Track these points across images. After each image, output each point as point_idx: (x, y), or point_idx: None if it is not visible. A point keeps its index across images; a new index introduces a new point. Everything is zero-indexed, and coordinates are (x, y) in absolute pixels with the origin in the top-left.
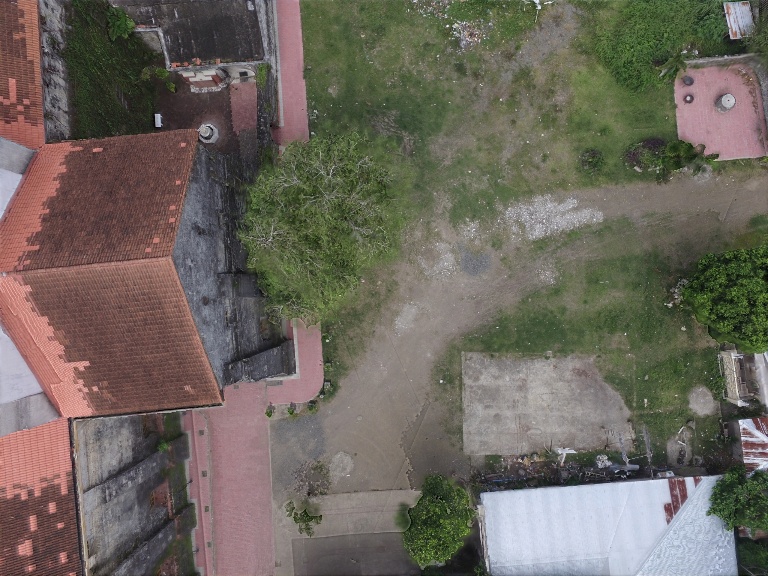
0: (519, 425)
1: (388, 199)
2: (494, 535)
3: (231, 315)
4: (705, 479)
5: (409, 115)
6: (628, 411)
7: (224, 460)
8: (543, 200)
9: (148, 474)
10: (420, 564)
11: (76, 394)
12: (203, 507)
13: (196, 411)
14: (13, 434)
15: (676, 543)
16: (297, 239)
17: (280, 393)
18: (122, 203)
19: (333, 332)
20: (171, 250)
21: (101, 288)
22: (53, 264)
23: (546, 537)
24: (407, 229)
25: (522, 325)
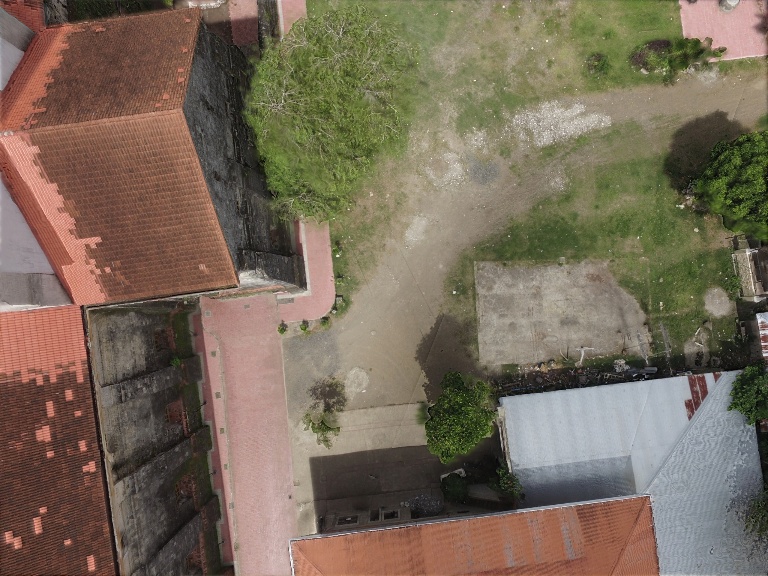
0: (535, 333)
1: (398, 71)
2: (515, 438)
3: (242, 206)
4: (725, 374)
5: (411, 25)
6: (644, 314)
7: (237, 381)
8: (550, 106)
9: (162, 386)
10: (442, 461)
11: (88, 277)
12: (218, 429)
13: (207, 332)
14: (25, 318)
15: (698, 439)
16: (309, 100)
17: (292, 311)
18: (129, 70)
19: (343, 247)
20: (182, 104)
21: (111, 148)
22: (61, 122)
23: (567, 438)
24: (414, 140)
25: (534, 233)
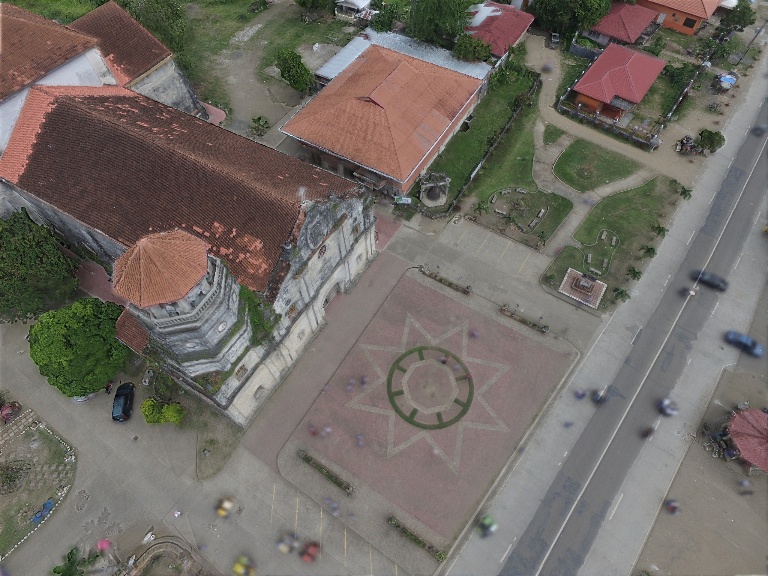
0: None
1: None
2: None
3: None
4: None
5: None
6: (331, 45)
7: None
8: (237, 33)
9: None
10: (302, 79)
11: (117, 72)
12: None
13: None
14: None
15: None
16: None
17: None
18: None
19: None
20: None
21: (97, 21)
22: None
23: (342, 67)
24: (201, 65)
25: (271, 55)
